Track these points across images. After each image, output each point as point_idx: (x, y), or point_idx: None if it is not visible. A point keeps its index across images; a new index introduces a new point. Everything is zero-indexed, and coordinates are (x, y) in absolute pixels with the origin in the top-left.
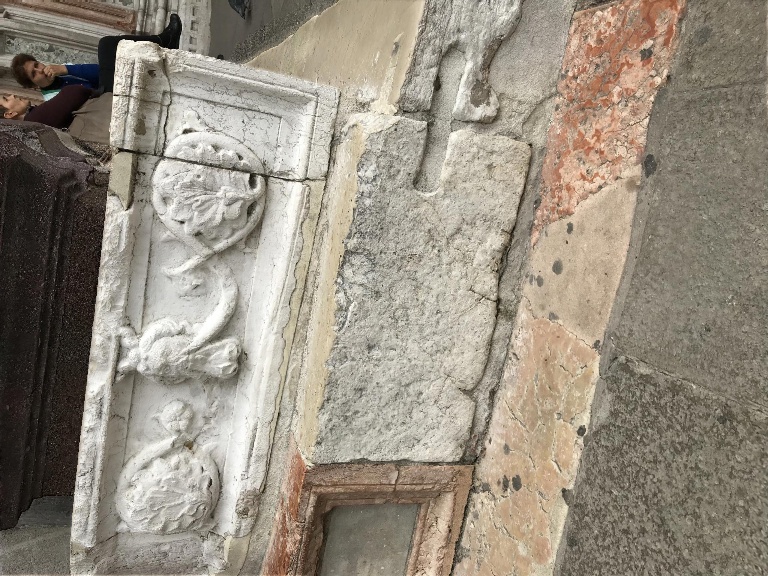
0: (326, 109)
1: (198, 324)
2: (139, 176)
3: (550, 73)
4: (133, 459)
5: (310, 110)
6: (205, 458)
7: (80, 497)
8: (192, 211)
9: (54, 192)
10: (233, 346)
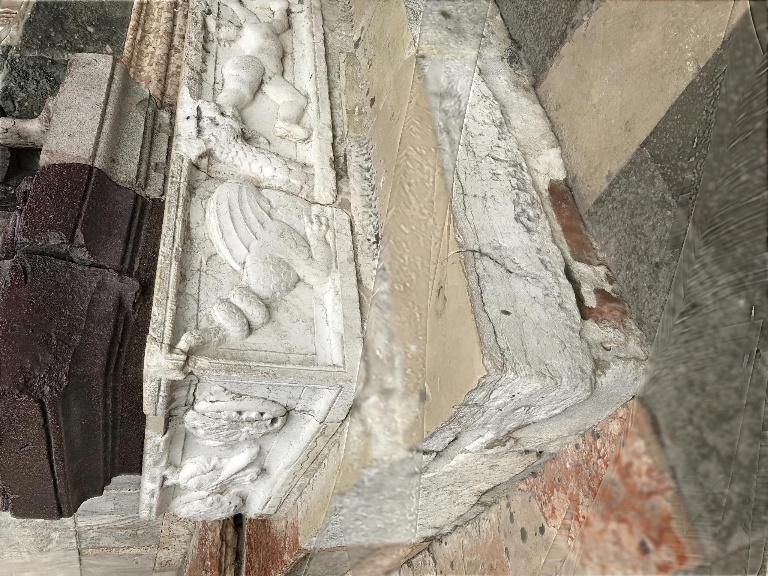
0: (349, 394)
1: (226, 460)
2: (172, 417)
3: (582, 425)
4: (179, 498)
5: (333, 392)
6: (232, 498)
7: (143, 514)
8: (219, 435)
9: (102, 385)
10: (254, 475)
